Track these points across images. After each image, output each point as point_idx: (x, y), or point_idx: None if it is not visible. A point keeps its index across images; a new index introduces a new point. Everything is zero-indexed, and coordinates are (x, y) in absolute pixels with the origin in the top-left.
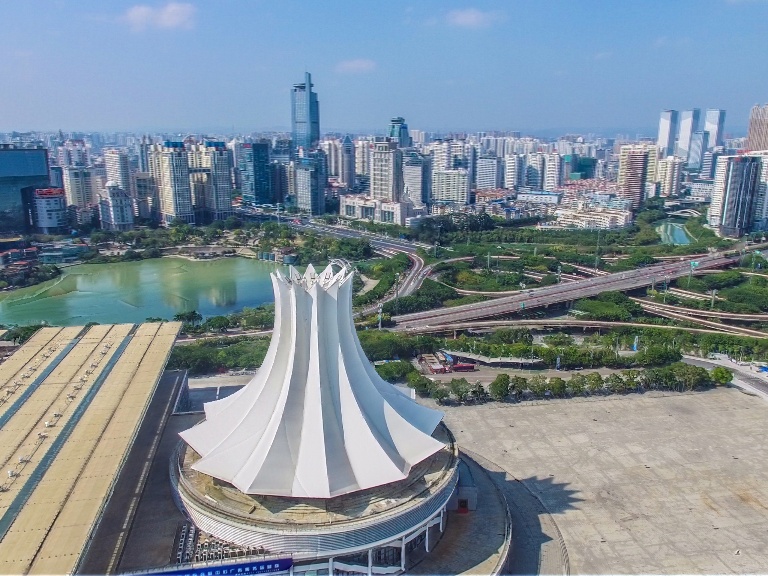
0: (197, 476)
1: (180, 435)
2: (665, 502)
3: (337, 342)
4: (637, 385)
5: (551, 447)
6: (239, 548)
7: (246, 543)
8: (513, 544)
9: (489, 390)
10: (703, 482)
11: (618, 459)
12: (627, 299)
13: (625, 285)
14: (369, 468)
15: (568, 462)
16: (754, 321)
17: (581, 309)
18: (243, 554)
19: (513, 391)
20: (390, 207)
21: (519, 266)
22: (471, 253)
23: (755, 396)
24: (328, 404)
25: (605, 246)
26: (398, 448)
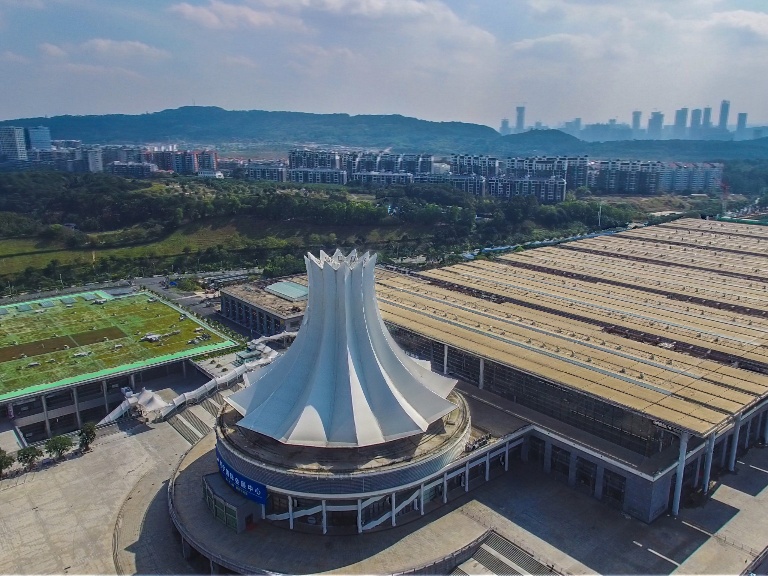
0: None
1: None
2: None
3: None
4: None
5: None
6: None
7: None
8: (168, 530)
9: None
10: None
11: None
12: None
13: None
14: None
15: None
16: None
17: None
18: None
19: None
20: None
21: None
22: None
23: None
24: None
25: None
26: None
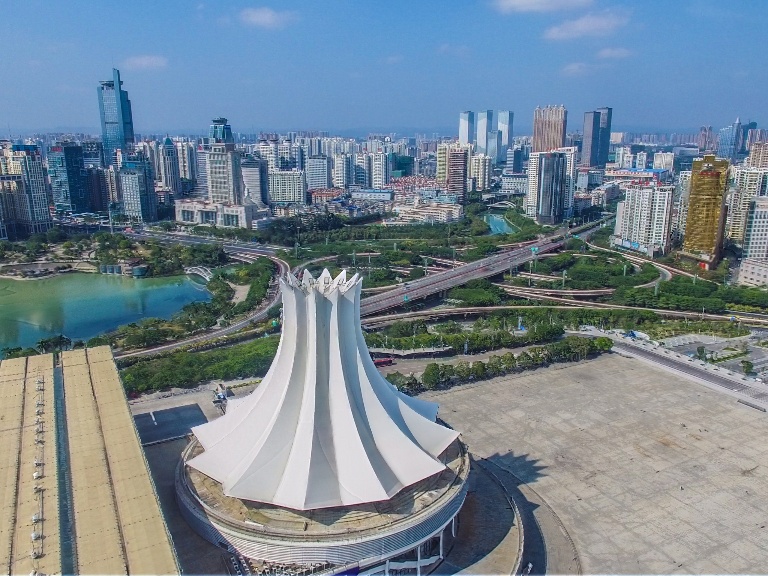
0: (222, 504)
1: (188, 464)
2: (610, 457)
3: (355, 345)
4: (543, 360)
5: (497, 425)
6: (301, 568)
7: (308, 561)
8: None
9: (422, 380)
10: (630, 435)
11: (556, 427)
12: (492, 285)
13: (485, 272)
14: (406, 465)
15: (518, 436)
16: (599, 295)
17: (455, 298)
18: (310, 573)
19: (442, 379)
20: (233, 210)
21: (385, 262)
22: (334, 252)
23: (632, 358)
24: (353, 408)
25: (450, 238)
26: (419, 442)
